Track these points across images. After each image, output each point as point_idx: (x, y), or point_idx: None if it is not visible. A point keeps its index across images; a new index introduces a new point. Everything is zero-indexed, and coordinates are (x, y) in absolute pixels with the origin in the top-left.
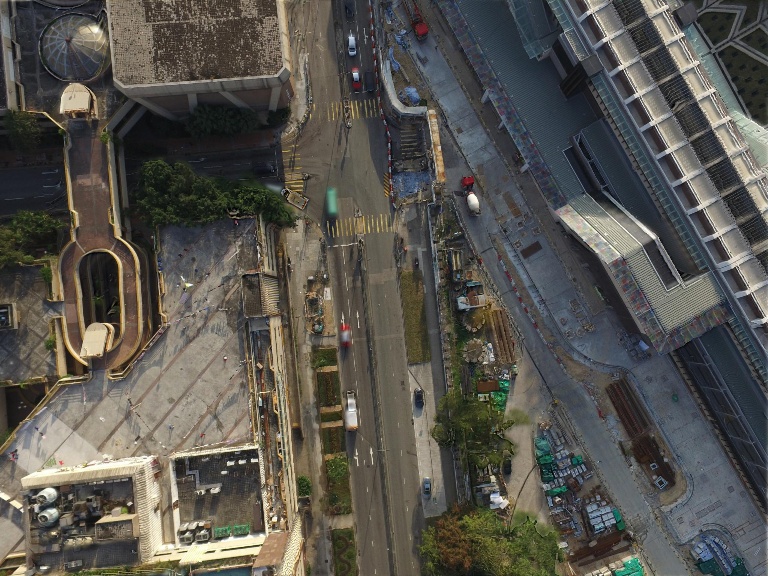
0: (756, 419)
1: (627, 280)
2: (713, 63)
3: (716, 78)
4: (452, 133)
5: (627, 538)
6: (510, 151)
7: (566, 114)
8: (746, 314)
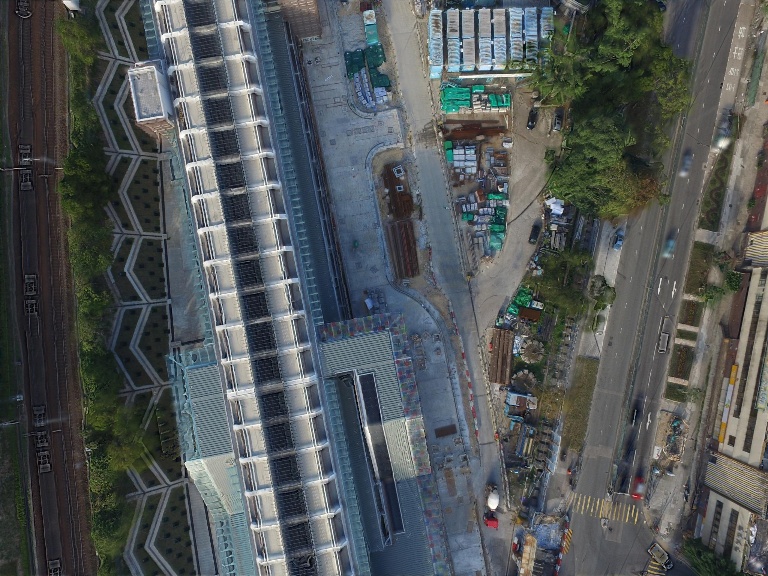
0: (307, 211)
1: (408, 396)
2: (204, 567)
3: (206, 550)
4: (487, 573)
5: (446, 131)
6: (444, 541)
7: (388, 569)
8: (306, 326)
